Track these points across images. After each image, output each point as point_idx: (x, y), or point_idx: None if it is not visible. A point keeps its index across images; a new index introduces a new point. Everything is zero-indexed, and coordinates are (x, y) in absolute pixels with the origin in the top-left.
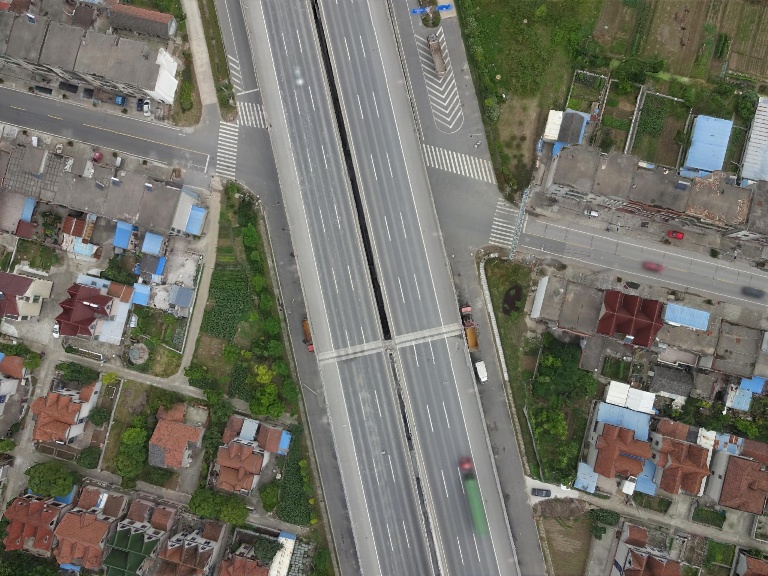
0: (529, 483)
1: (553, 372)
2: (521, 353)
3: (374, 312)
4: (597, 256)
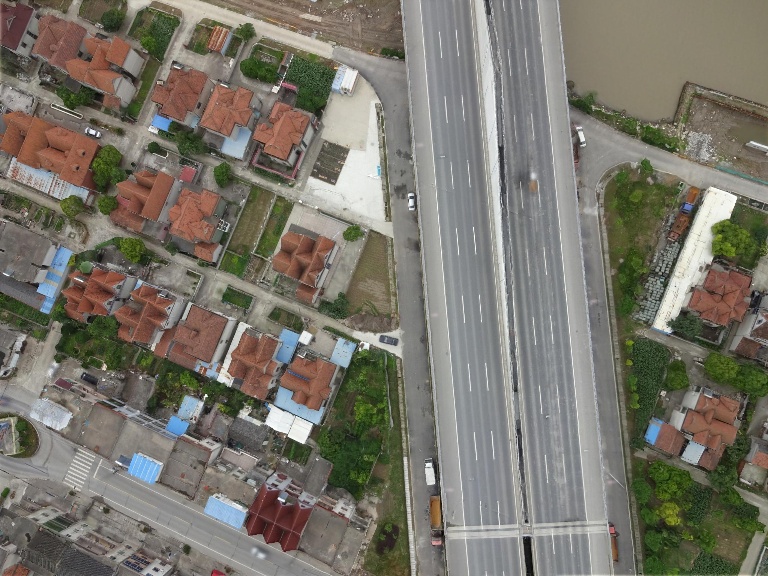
0: (399, 351)
1: (359, 464)
2: (387, 483)
3: (538, 567)
4: (296, 568)
